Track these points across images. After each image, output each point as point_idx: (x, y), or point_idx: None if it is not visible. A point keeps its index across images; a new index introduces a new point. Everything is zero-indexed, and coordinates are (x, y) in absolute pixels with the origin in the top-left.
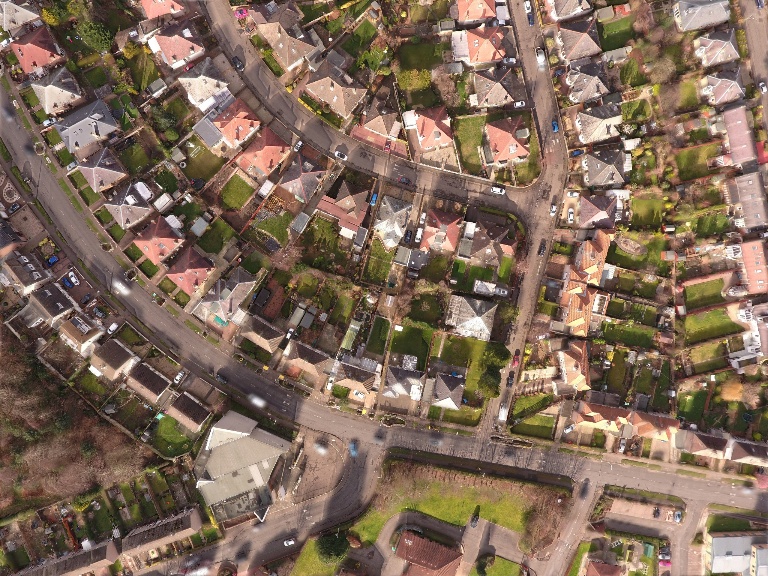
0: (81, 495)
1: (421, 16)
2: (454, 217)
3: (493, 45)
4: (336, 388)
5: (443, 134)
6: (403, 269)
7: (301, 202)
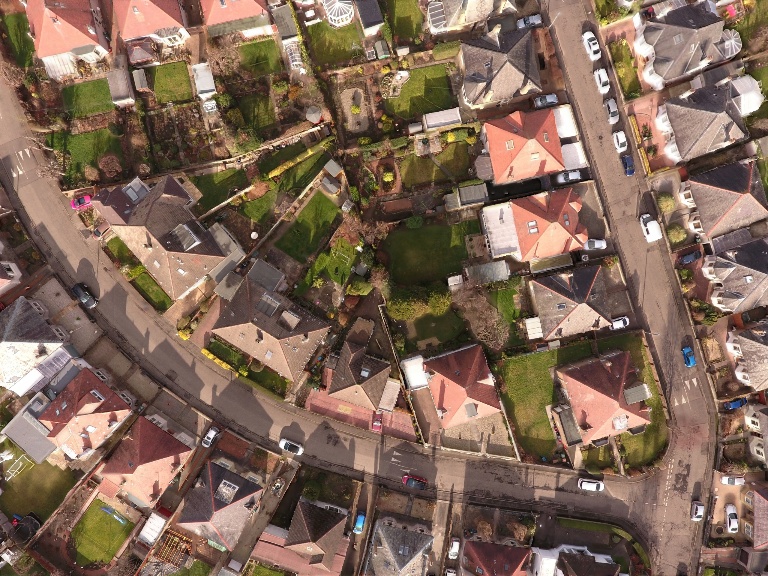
0: None
1: (421, 176)
2: (515, 555)
3: (566, 229)
4: None
5: (482, 405)
6: None
7: None
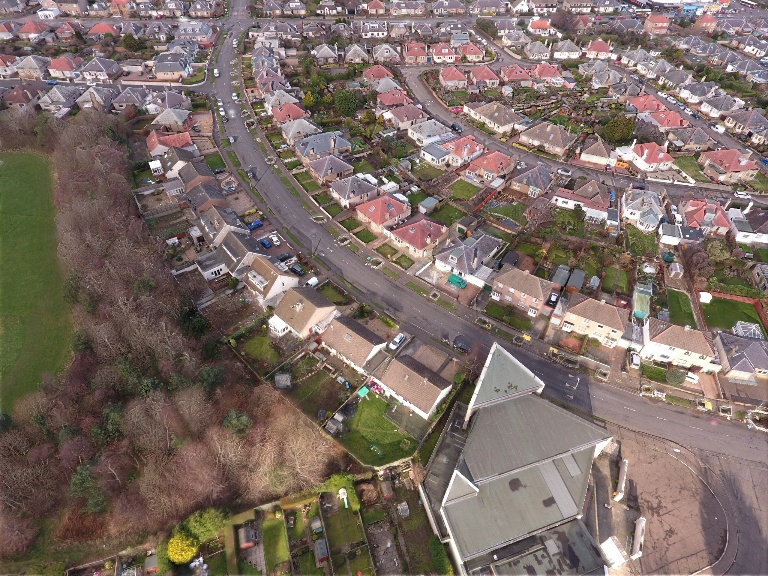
0: (197, 509)
1: (603, 114)
2: None
3: (678, 116)
4: (645, 368)
5: (665, 153)
6: (674, 248)
7: (533, 198)
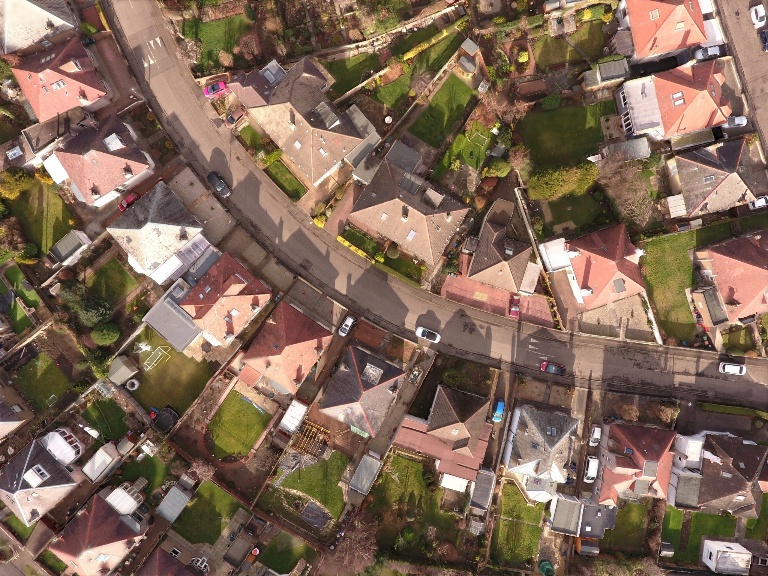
0: None
1: (555, 56)
2: (662, 436)
3: (713, 99)
4: None
5: (629, 282)
6: (565, 534)
7: None
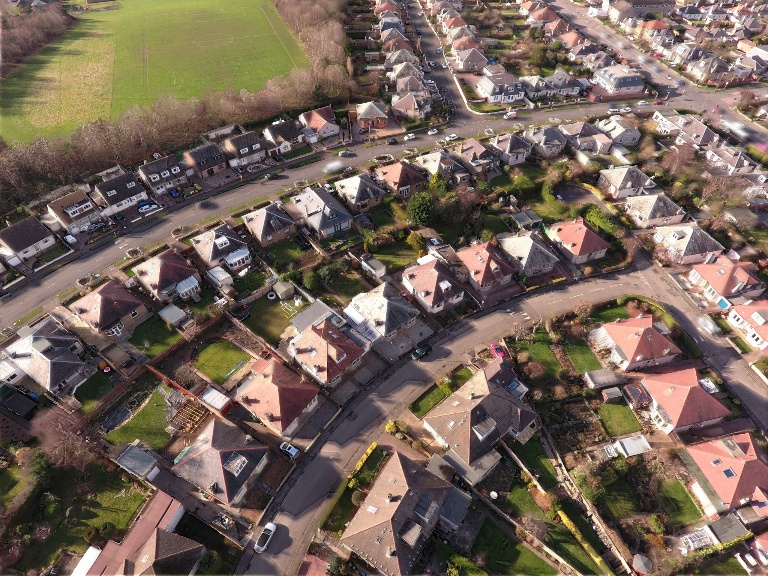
0: None
1: None
2: None
3: None
4: None
5: None
6: None
7: None
